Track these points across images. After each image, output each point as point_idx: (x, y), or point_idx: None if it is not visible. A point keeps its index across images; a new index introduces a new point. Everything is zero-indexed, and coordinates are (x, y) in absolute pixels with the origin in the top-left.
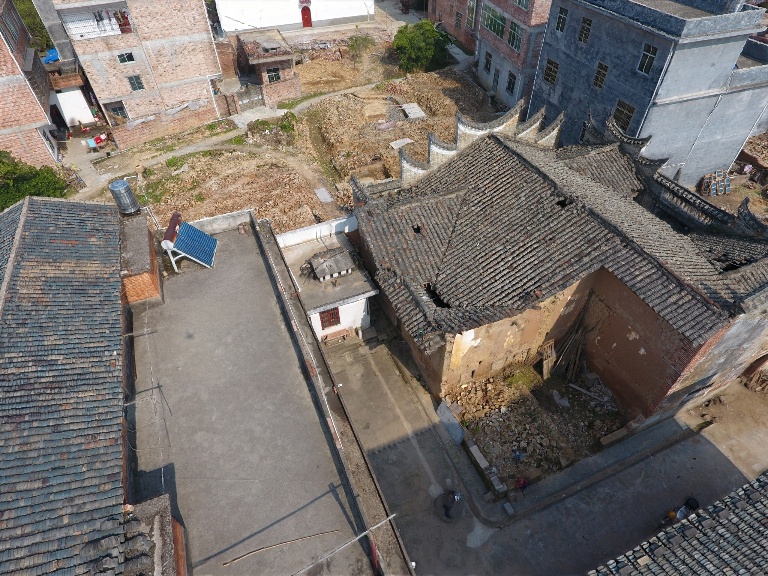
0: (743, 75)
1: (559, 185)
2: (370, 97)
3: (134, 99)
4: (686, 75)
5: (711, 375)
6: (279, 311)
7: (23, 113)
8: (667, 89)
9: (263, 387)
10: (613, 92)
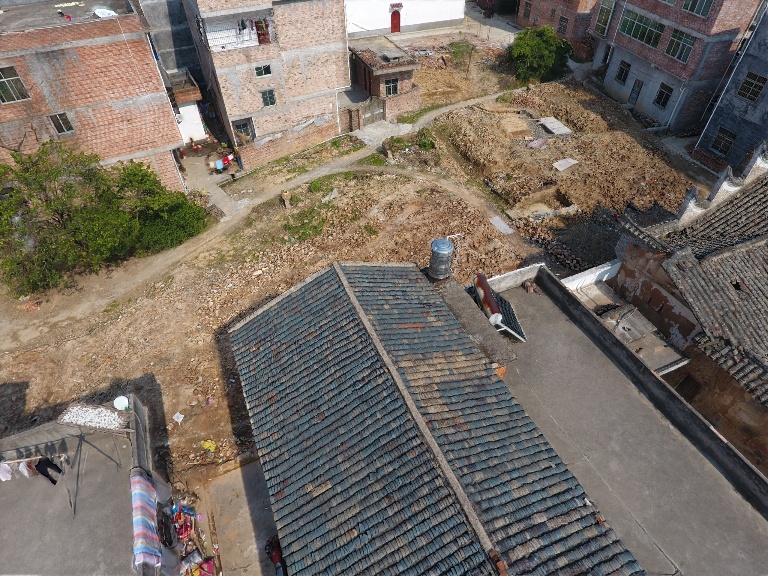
0: None
1: None
2: (499, 110)
3: (264, 115)
4: None
5: None
6: (651, 404)
7: (160, 134)
8: None
9: (711, 523)
10: None
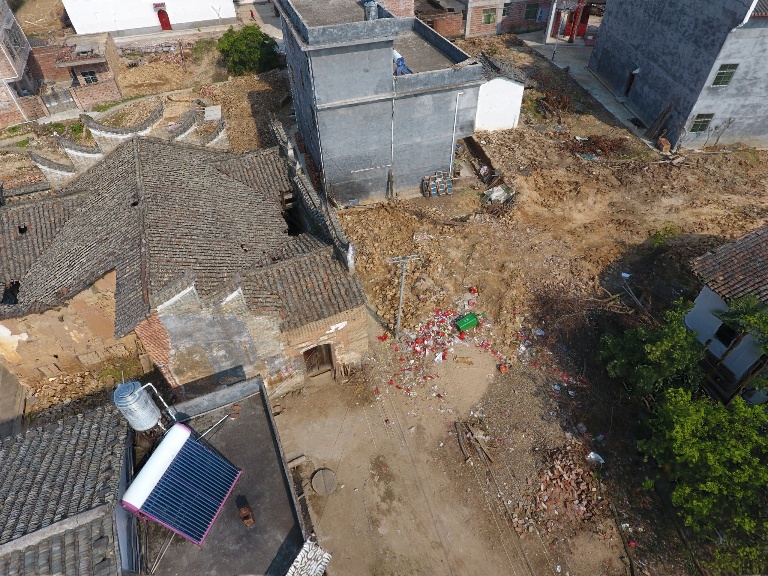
0: (410, 80)
1: (139, 187)
2: (180, 100)
3: None
4: (339, 81)
5: (234, 367)
6: None
7: None
8: (325, 94)
9: None
10: (307, 96)
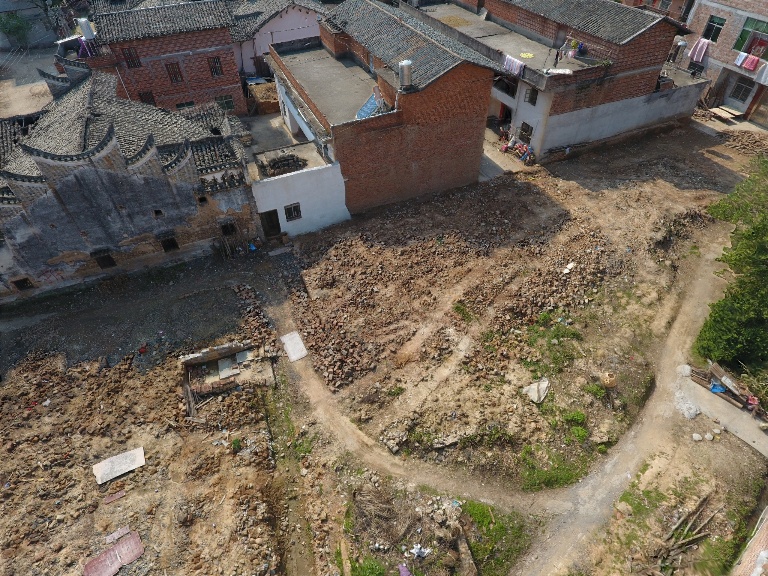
0: None
1: None
2: None
3: None
4: None
5: None
6: None
7: None
8: None
9: None
10: None
